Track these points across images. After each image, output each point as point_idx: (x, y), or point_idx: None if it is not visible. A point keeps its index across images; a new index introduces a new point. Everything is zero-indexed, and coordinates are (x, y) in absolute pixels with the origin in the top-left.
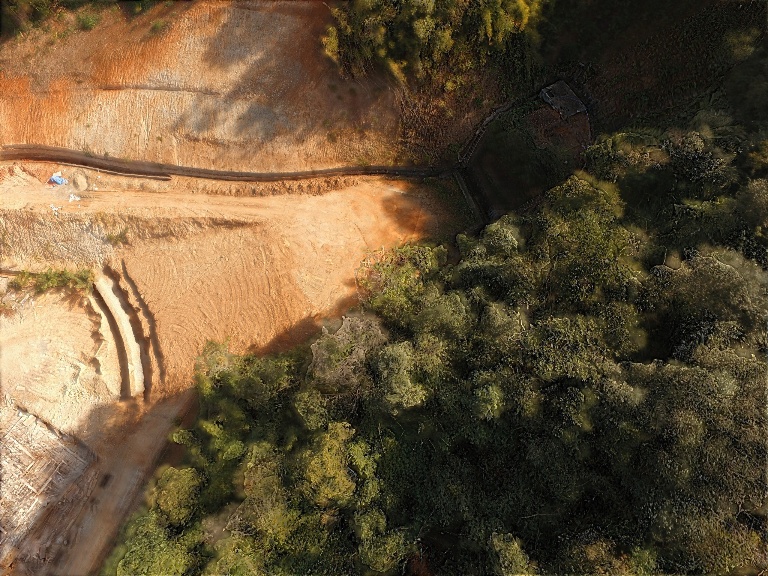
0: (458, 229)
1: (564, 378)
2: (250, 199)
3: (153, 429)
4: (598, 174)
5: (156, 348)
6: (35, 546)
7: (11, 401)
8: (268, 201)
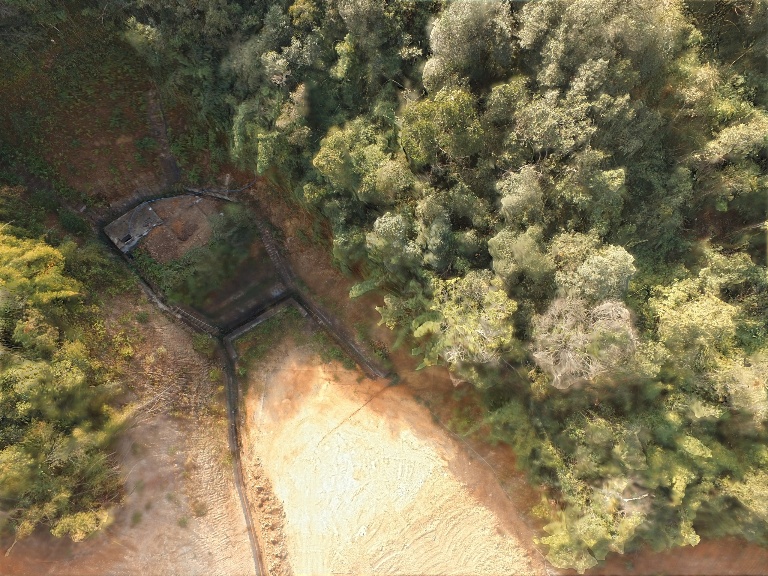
0: (303, 323)
1: (593, 110)
2: None
3: None
4: (287, 153)
5: None
6: None
7: None
8: None
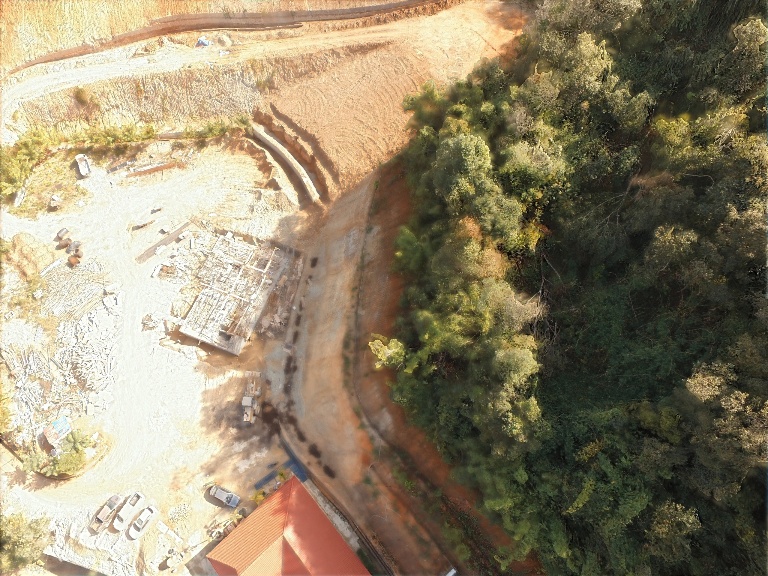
0: None
1: None
2: (377, 27)
3: (343, 213)
4: None
5: (322, 161)
6: (266, 320)
7: (208, 224)
8: (393, 26)
